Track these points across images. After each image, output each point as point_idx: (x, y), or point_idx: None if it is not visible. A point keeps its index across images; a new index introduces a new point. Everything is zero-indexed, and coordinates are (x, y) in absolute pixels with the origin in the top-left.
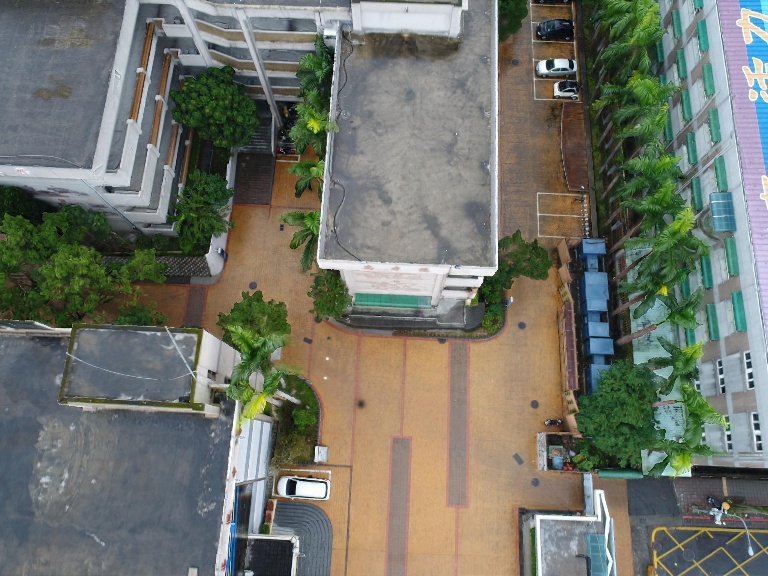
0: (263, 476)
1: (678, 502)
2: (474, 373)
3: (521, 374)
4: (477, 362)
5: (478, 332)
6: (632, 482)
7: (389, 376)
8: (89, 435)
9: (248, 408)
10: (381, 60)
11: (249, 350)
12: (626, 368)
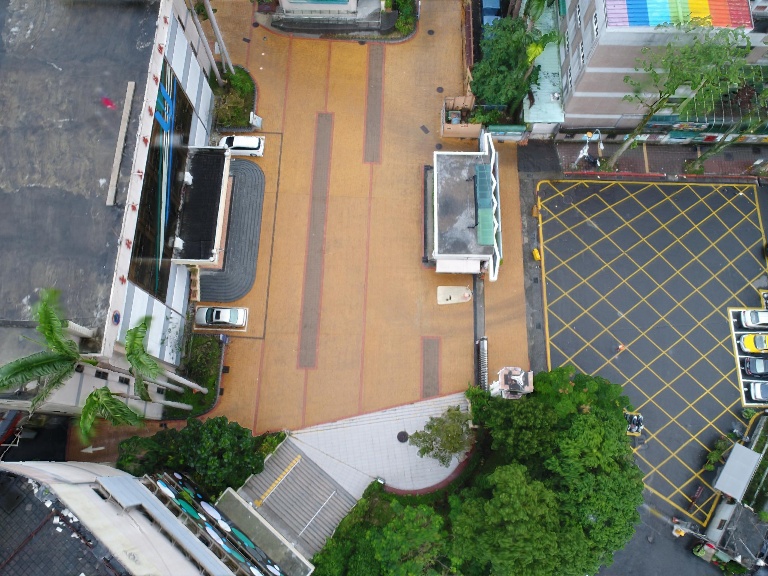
0: (205, 125)
1: (560, 162)
2: (389, 67)
3: (429, 68)
4: (392, 59)
5: (393, 35)
6: (522, 148)
7: (316, 68)
8: (50, 1)
9: None
10: None
11: None
12: None
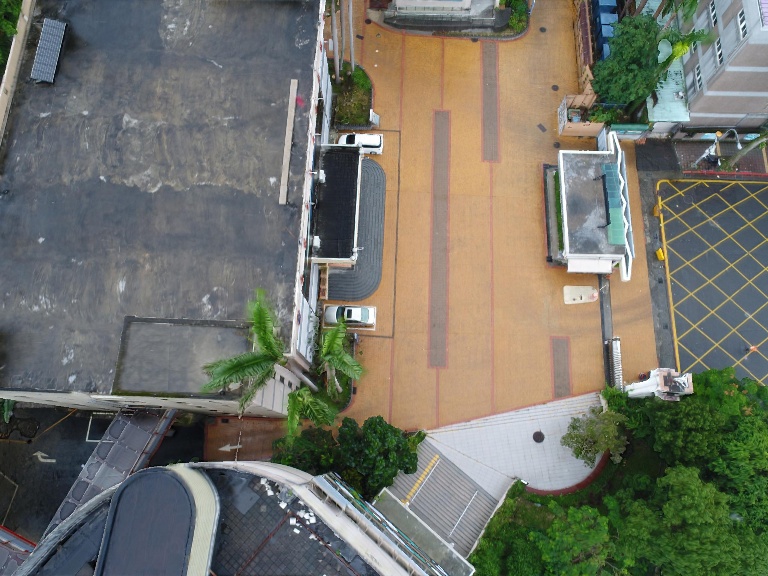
0: (328, 123)
1: (679, 161)
2: (503, 64)
3: (543, 65)
4: (505, 56)
5: (505, 33)
6: (639, 147)
7: (430, 65)
8: None
9: None
10: None
11: None
12: None
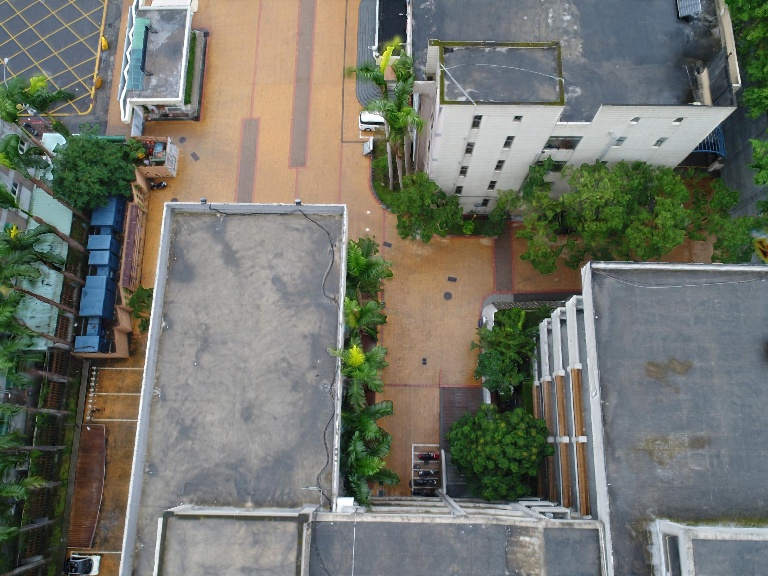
0: None
1: None
2: None
3: None
4: None
5: None
6: None
7: None
8: None
9: (422, 135)
10: (282, 465)
11: None
12: (74, 195)
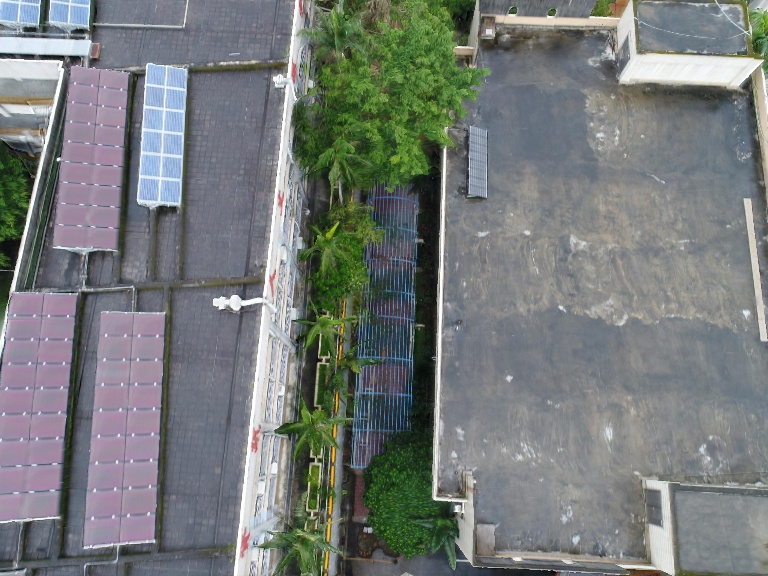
0: None
1: None
2: None
3: None
4: None
5: None
6: None
7: None
8: (629, 102)
9: None
10: None
11: (763, 32)
12: None
